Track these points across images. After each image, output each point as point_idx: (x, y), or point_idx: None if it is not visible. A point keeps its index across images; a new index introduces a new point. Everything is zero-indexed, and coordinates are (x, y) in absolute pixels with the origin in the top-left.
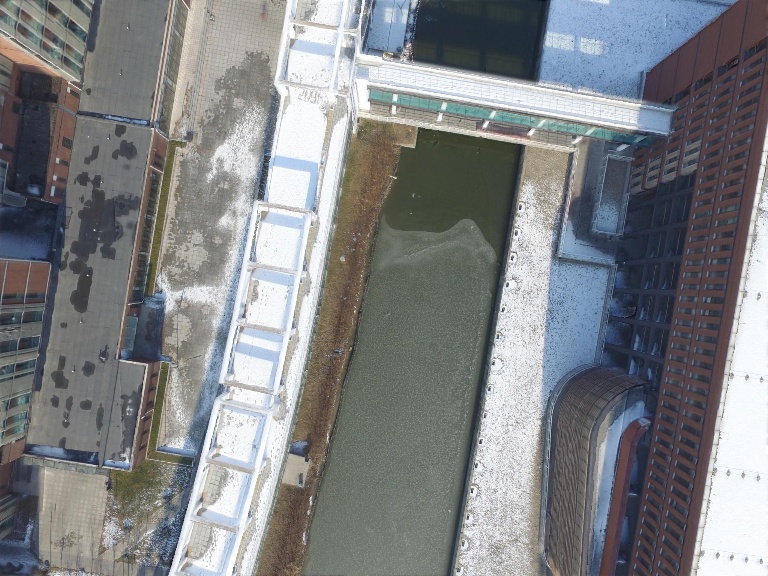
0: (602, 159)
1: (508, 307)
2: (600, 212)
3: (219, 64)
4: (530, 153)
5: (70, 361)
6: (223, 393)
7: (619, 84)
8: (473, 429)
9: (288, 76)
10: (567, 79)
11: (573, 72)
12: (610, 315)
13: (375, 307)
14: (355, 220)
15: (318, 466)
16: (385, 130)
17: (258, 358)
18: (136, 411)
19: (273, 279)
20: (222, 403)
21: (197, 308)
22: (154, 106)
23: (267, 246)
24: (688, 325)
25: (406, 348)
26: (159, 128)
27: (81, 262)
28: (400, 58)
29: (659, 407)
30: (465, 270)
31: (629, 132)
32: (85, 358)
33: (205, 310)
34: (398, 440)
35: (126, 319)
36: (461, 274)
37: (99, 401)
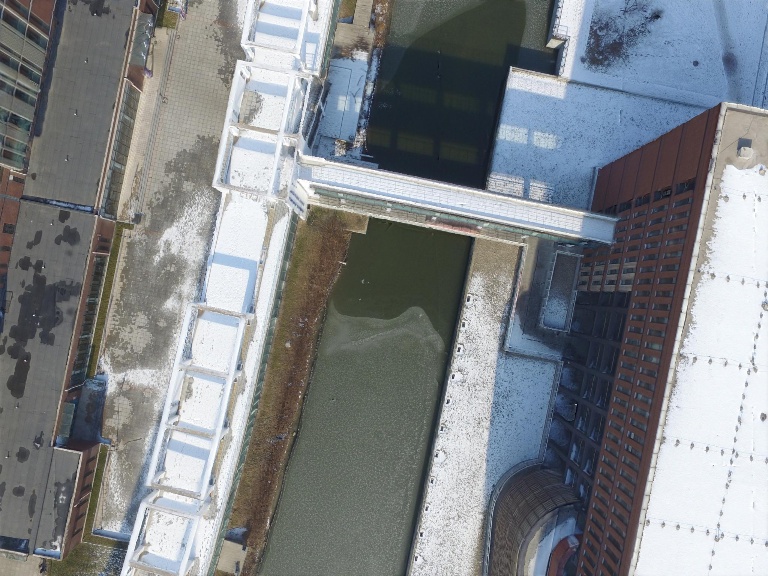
0: (552, 254)
1: (453, 399)
2: (549, 306)
3: (170, 147)
4: (480, 245)
5: (4, 446)
6: (152, 492)
7: (571, 179)
8: (415, 519)
9: (230, 173)
10: (519, 172)
11: (525, 165)
12: (554, 413)
13: (320, 392)
14: (302, 306)
15: (257, 552)
16: (336, 216)
17: (190, 456)
18: (69, 499)
19: (208, 376)
20: (148, 506)
21: (139, 391)
22: (99, 193)
23: (203, 343)
24: (614, 454)
25: (350, 435)
26: (105, 212)
27: (19, 347)
28: (353, 144)
29: (586, 531)
30: (412, 358)
31: (572, 239)
32: (20, 444)
33: (147, 393)
34: (339, 528)
35: (63, 405)
36: (408, 362)
37: (32, 488)
